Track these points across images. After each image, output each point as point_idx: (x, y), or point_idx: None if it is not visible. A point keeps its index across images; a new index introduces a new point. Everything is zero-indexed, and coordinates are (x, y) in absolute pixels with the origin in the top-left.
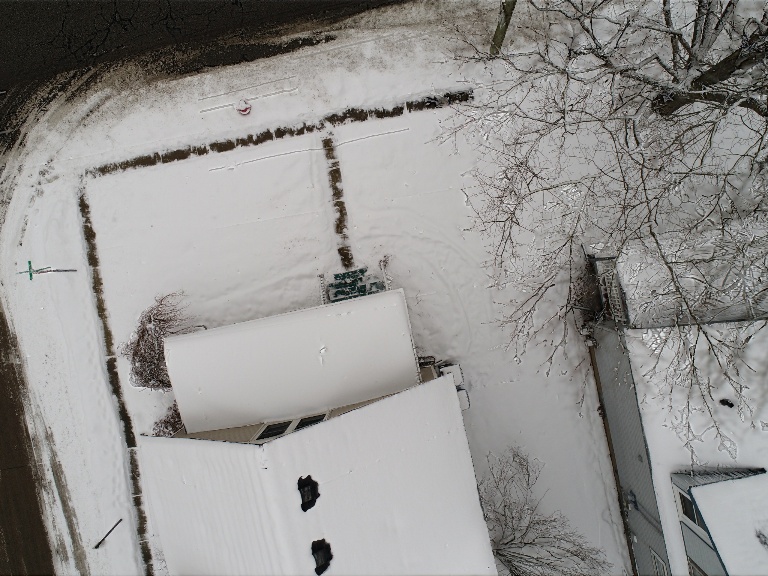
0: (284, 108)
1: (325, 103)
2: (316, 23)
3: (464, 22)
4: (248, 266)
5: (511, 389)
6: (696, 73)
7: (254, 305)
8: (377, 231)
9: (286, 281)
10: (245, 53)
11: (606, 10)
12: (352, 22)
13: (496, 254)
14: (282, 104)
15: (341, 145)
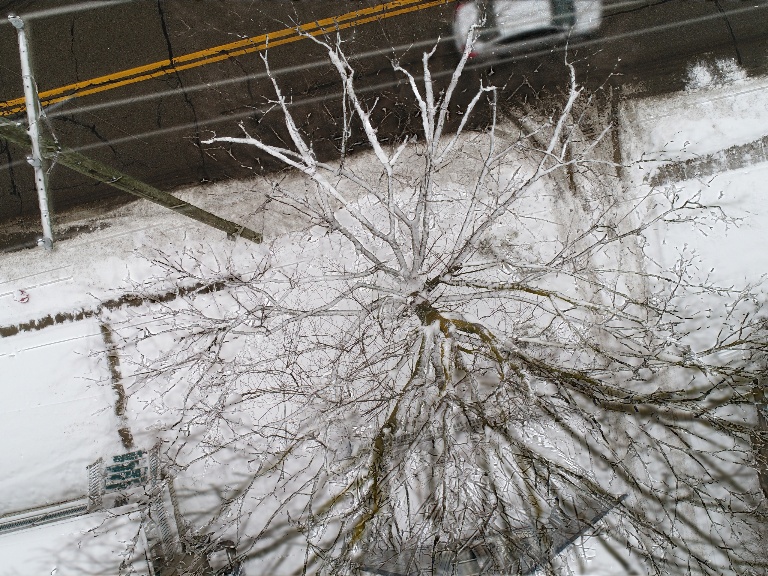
0: (61, 296)
1: (100, 290)
2: (91, 211)
3: (229, 211)
4: (30, 450)
5: (287, 563)
6: (412, 289)
7: (37, 488)
8: (153, 414)
9: (67, 464)
10: (25, 240)
11: (361, 200)
12: (125, 210)
13: (135, 541)
14: (59, 292)
15: (117, 330)
